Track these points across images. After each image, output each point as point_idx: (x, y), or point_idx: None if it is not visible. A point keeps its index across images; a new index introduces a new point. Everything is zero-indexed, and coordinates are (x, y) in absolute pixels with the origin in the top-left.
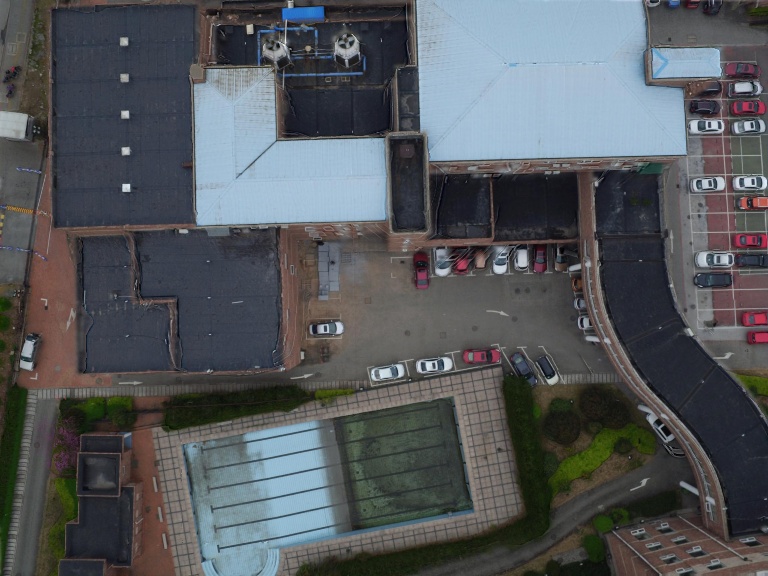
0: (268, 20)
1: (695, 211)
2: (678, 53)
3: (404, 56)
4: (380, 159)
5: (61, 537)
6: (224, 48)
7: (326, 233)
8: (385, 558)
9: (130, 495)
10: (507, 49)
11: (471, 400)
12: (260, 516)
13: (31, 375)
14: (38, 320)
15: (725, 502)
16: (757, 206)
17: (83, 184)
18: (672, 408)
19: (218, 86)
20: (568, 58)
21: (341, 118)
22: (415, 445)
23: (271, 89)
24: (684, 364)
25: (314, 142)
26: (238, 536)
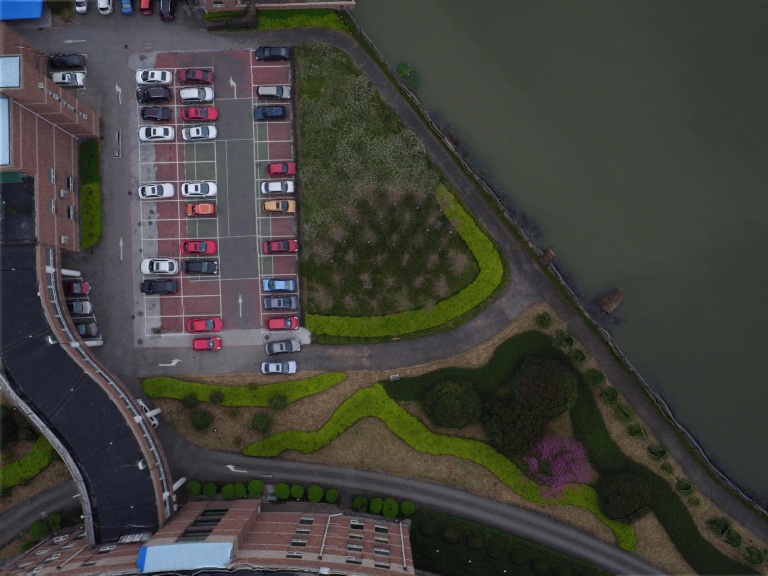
0: None
1: (146, 218)
2: None
3: None
4: None
5: None
6: None
7: None
8: None
9: None
10: None
11: None
12: None
13: None
14: None
15: (92, 510)
16: (198, 212)
17: None
18: (42, 416)
19: None
20: None
21: None
22: None
23: None
24: (56, 372)
25: None
26: None
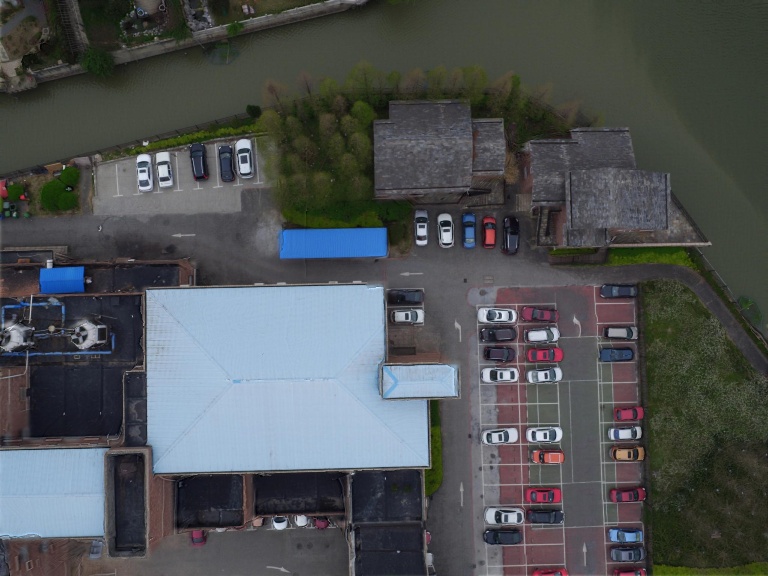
0: (29, 276)
1: (487, 462)
2: (409, 372)
3: None
4: (102, 473)
5: None
6: None
7: None
8: None
9: None
10: (232, 363)
11: None
12: None
13: None
14: None
15: None
16: (548, 462)
17: None
18: None
19: None
20: (295, 374)
21: (90, 397)
22: None
23: None
24: None
25: (35, 452)
26: None
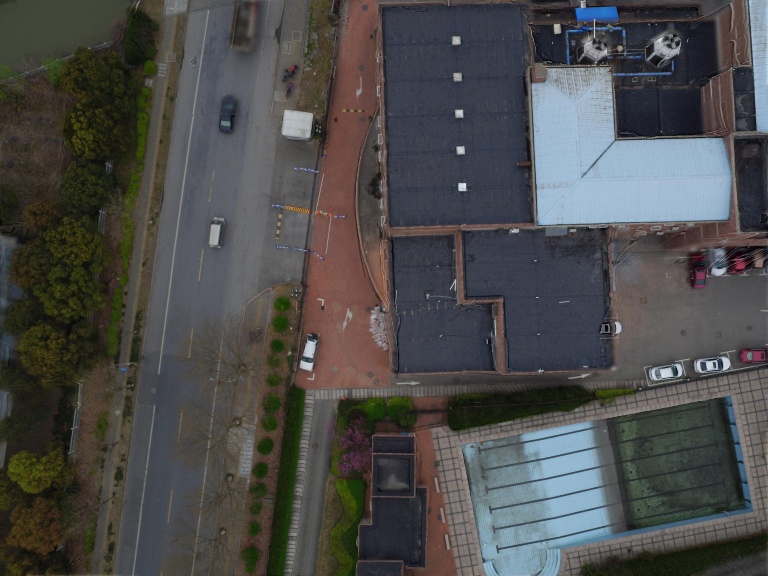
0: (556, 20)
1: None
2: None
3: (727, 56)
4: (721, 159)
5: (344, 538)
6: (540, 47)
7: (647, 233)
8: (671, 558)
9: (423, 496)
10: None
11: (748, 399)
12: (539, 516)
13: (308, 376)
14: (314, 320)
15: None
16: None
17: (416, 183)
18: None
19: (558, 85)
20: None
21: (648, 118)
22: (687, 444)
23: (609, 89)
24: None
25: (653, 142)
26: (517, 536)
